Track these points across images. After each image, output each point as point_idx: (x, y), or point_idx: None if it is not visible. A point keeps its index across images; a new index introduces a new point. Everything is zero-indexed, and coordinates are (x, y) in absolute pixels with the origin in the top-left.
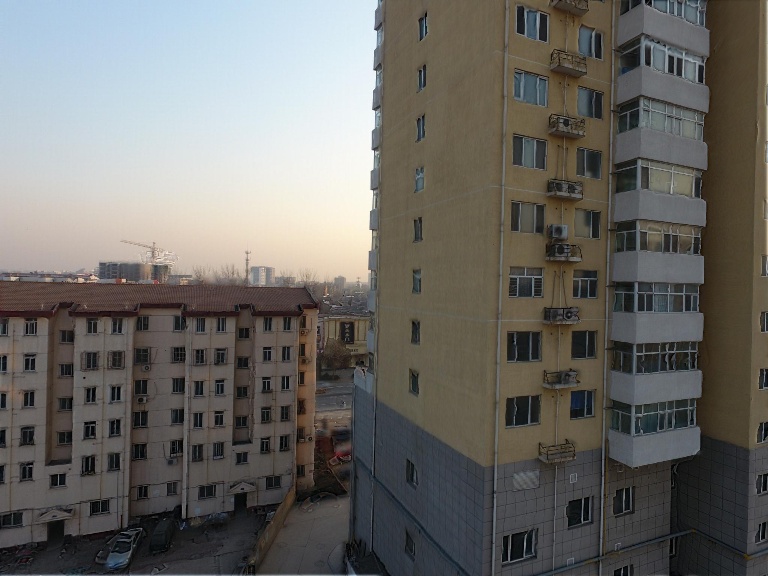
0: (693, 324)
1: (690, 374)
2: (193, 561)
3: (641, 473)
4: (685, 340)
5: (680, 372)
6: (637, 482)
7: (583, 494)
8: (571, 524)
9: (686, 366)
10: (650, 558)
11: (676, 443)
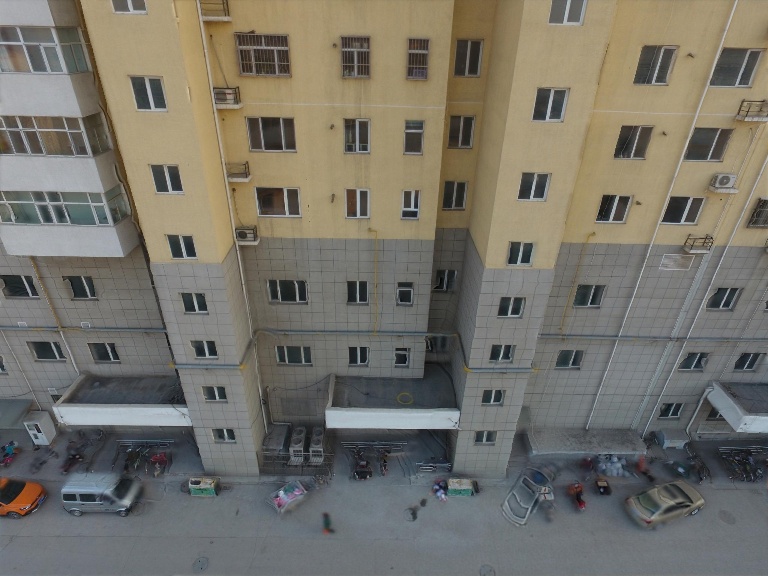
0: (54, 92)
1: (70, 161)
2: None
3: (97, 265)
4: (45, 114)
5: (50, 157)
6: (94, 273)
7: (15, 272)
8: (10, 295)
9: (71, 150)
10: (139, 343)
11: (74, 240)
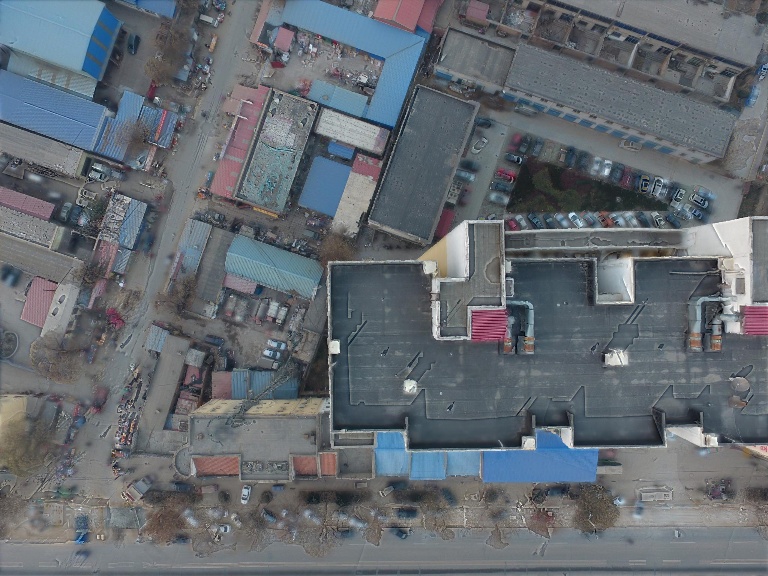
0: None
1: None
2: None
3: None
4: None
5: None
6: None
7: None
8: None
9: None
10: None
11: None
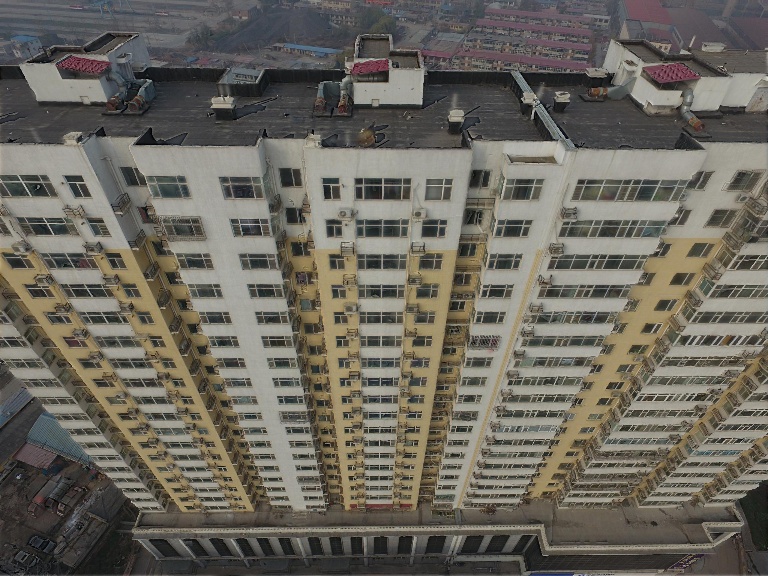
0: None
1: None
2: None
3: None
4: None
5: None
6: None
7: None
8: None
9: None
10: None
11: None
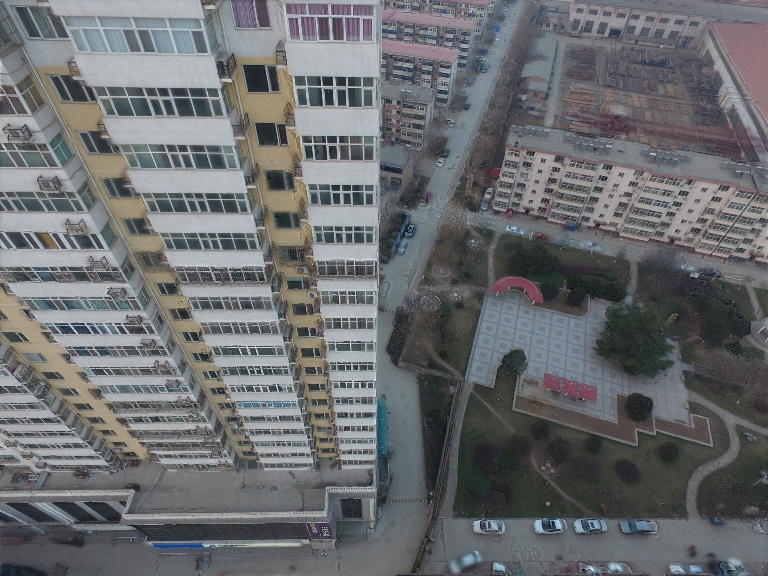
0: None
1: None
2: (459, 559)
3: None
4: None
5: None
6: None
7: None
8: None
9: None
10: None
11: None
